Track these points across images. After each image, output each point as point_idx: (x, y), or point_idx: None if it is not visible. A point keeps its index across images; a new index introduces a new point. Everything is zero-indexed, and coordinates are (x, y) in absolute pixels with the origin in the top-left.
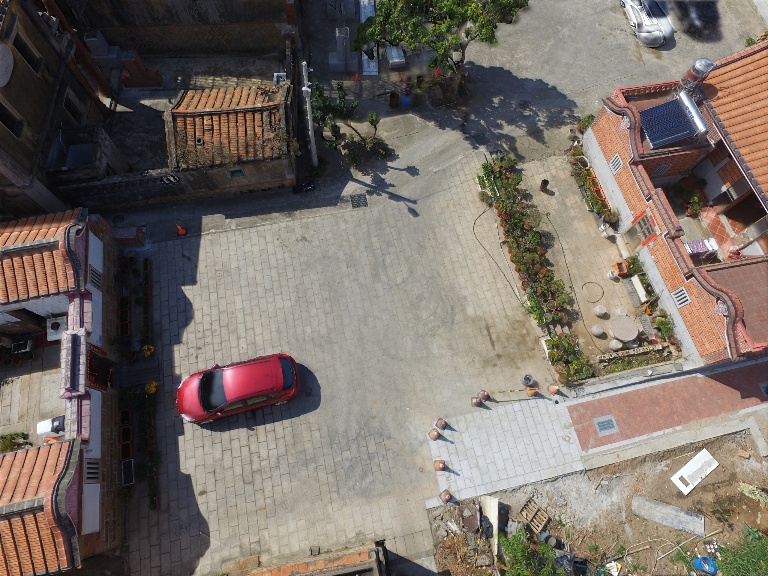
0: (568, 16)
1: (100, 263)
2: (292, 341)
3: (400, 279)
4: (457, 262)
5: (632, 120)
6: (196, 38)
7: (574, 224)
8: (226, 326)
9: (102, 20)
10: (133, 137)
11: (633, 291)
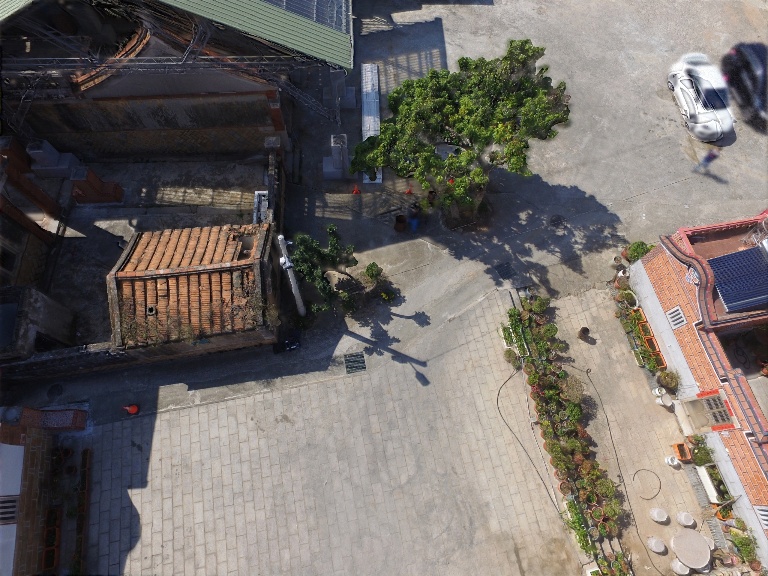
0: (607, 103)
1: (17, 480)
2: (264, 573)
3: (405, 477)
4: (477, 451)
5: (703, 278)
6: (165, 142)
7: (621, 385)
8: (181, 550)
9: (50, 126)
10: (82, 272)
11: (698, 483)
